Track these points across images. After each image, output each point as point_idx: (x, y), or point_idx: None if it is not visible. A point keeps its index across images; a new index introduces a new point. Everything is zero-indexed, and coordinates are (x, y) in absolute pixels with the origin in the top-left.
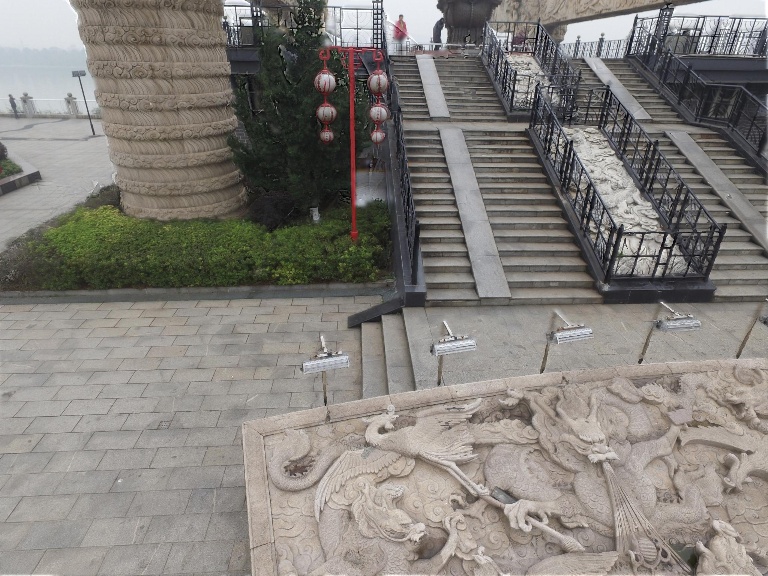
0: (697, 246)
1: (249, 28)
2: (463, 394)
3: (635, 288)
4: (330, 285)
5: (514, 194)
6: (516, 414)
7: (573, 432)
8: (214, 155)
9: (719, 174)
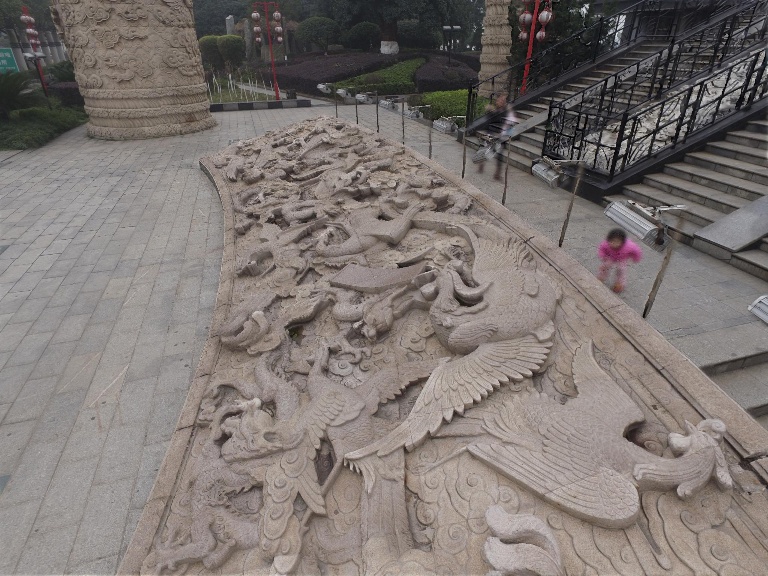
0: (639, 148)
1: None
2: (351, 125)
3: None
4: None
5: None
6: None
7: None
8: None
9: None
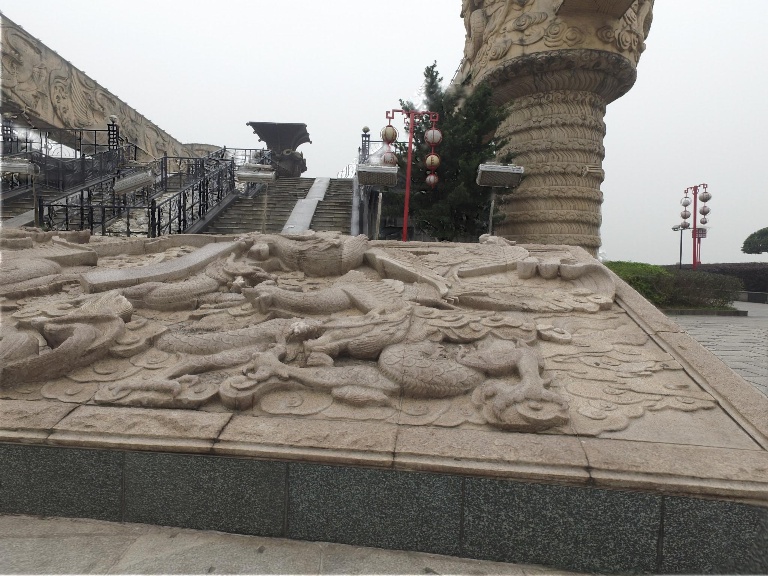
0: None
1: (1, 143)
2: None
3: None
4: None
5: None
6: None
7: None
8: None
9: (306, 217)
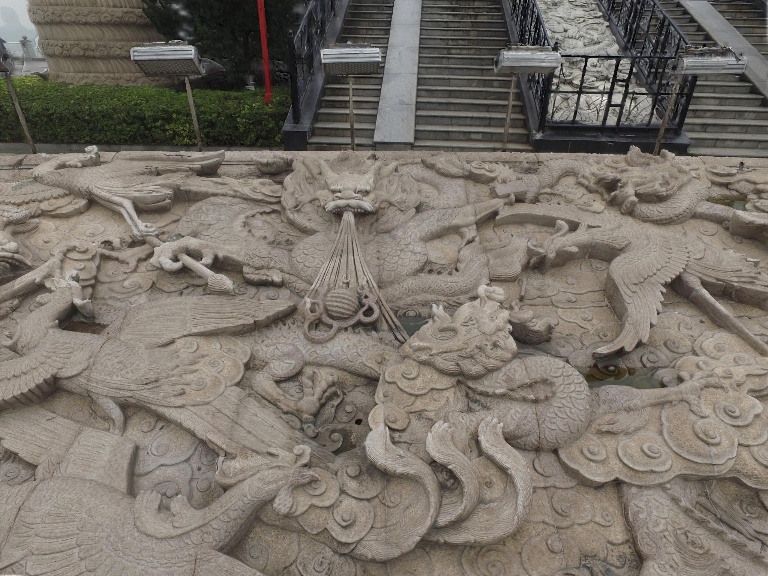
0: None
1: None
2: None
3: (577, 138)
4: (232, 148)
5: (463, 55)
6: (277, 180)
7: (326, 185)
8: (133, 14)
9: (738, 38)
